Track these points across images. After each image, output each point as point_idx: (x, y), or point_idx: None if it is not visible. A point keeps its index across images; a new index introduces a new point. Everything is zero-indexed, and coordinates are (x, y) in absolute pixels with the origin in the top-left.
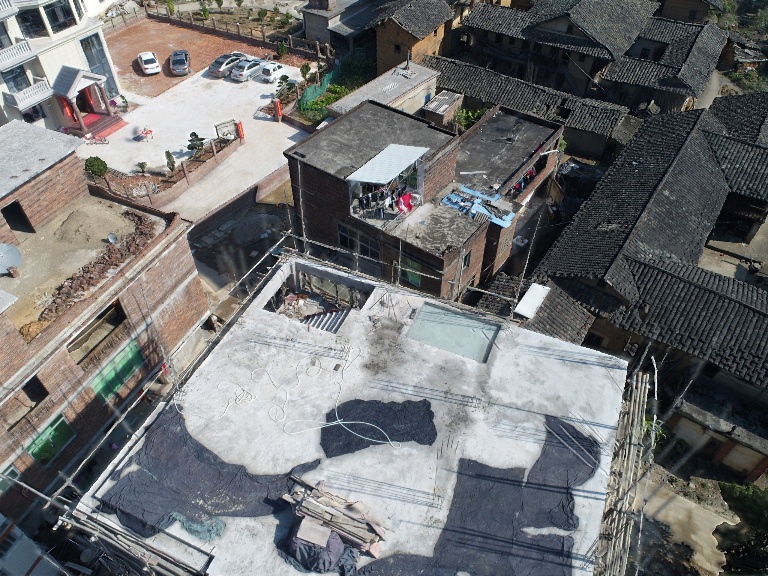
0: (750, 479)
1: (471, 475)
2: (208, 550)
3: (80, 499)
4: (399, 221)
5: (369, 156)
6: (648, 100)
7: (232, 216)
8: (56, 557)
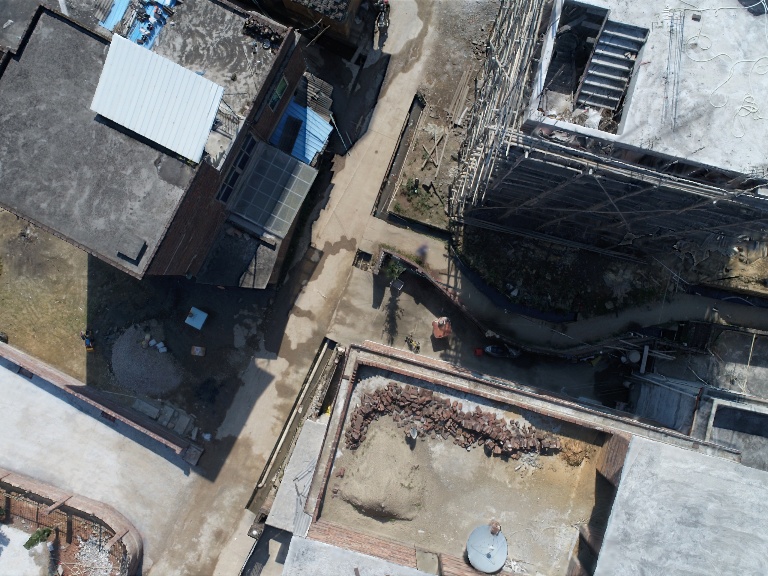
0: None
1: None
2: None
3: None
4: None
5: (124, 142)
6: None
7: (125, 408)
8: (622, 394)
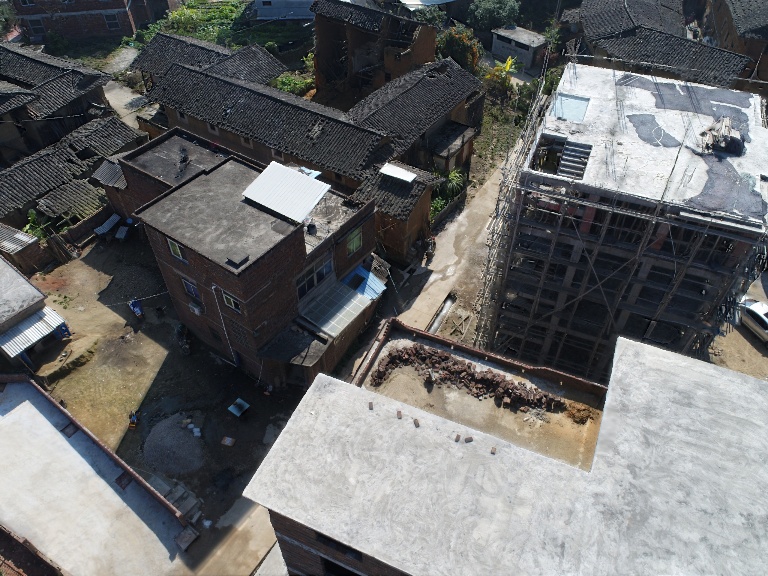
0: (470, 157)
1: (664, 105)
2: (759, 177)
3: (766, 233)
4: (304, 233)
5: (255, 212)
6: (87, 107)
7: None
8: None
